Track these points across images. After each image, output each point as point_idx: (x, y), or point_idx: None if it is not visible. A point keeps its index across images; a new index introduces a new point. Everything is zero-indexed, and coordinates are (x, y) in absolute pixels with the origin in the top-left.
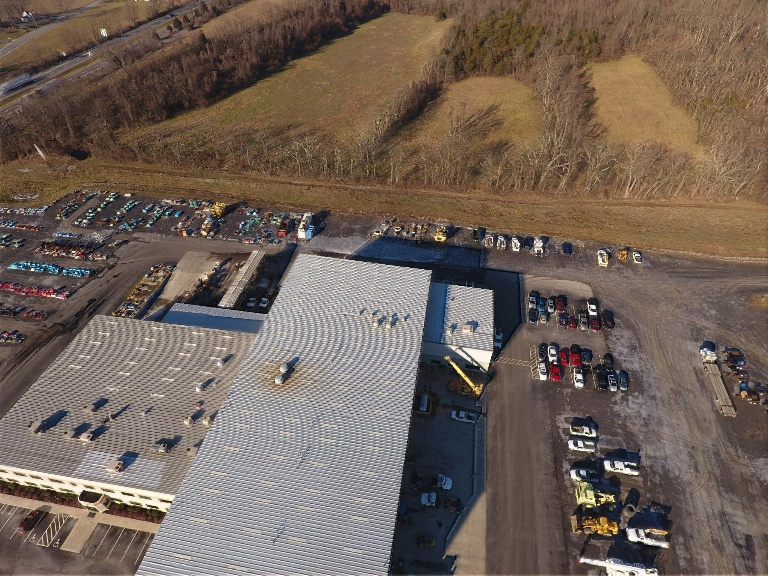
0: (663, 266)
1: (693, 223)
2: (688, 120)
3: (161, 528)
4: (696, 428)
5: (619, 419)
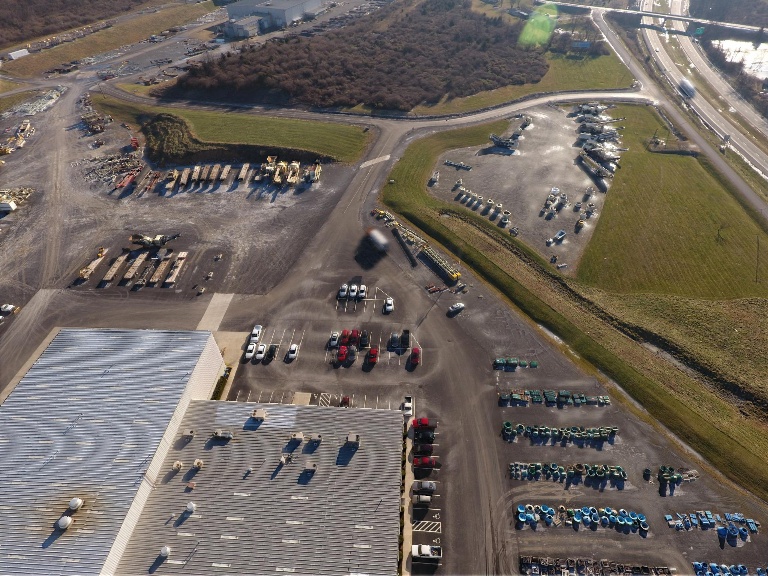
0: None
1: None
2: None
3: (195, 362)
4: None
5: None
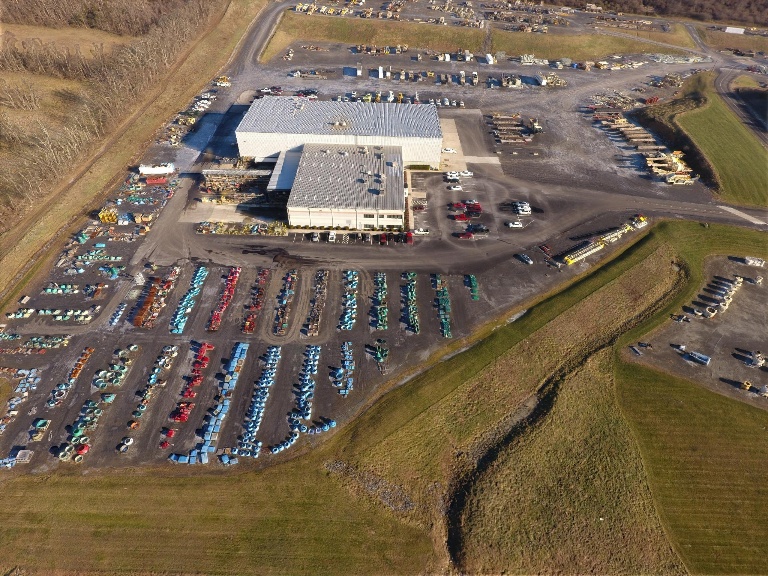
0: (232, 75)
1: (202, 58)
2: (89, 30)
3: (419, 136)
4: (333, 83)
5: (331, 94)
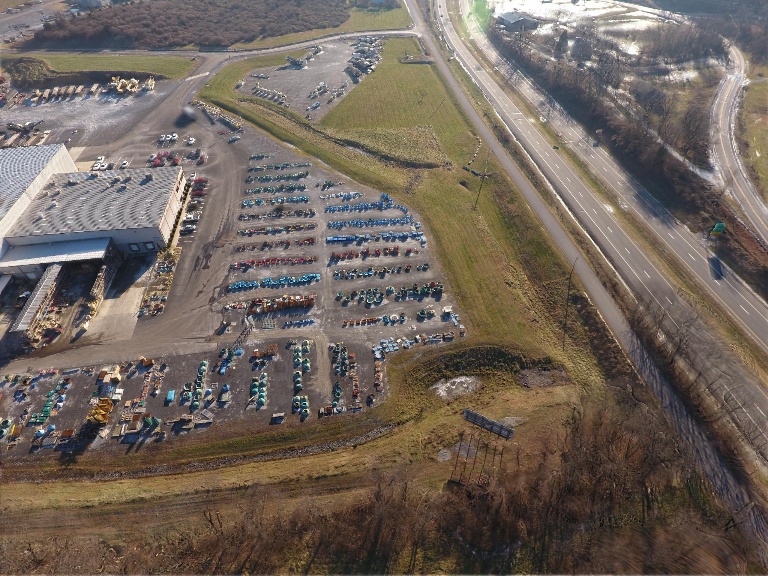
0: None
1: None
2: None
3: (53, 154)
4: None
5: None
